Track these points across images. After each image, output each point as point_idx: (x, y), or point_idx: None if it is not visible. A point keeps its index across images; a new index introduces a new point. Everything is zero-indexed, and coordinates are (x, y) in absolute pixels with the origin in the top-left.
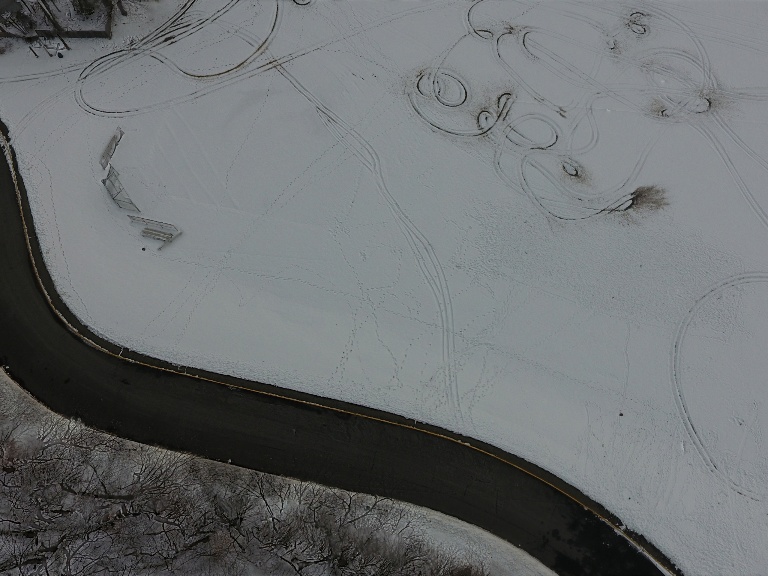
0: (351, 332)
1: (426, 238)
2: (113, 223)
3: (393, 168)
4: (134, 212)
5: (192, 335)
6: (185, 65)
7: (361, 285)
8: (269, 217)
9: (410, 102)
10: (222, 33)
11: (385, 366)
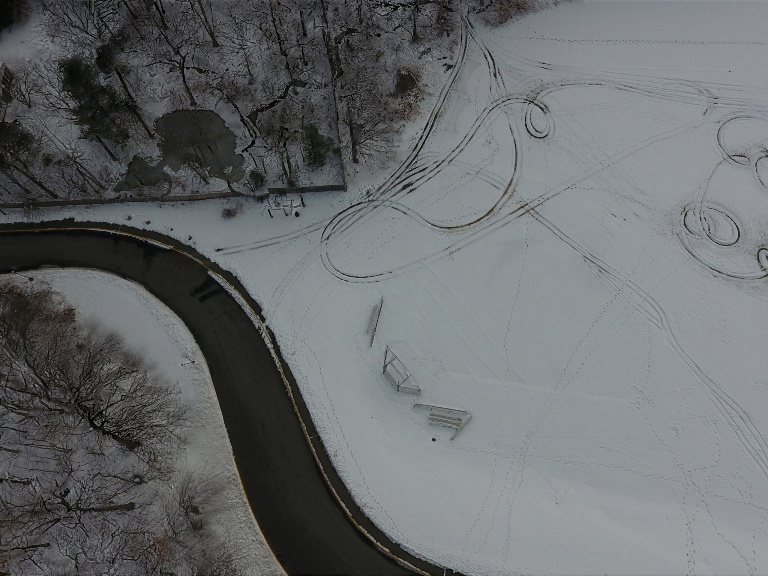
0: (686, 527)
1: (738, 404)
2: (394, 410)
3: (682, 323)
4: (414, 395)
5: (519, 547)
6: (431, 216)
7: (681, 467)
8: (562, 391)
9: (681, 243)
10: (462, 176)
11: (737, 568)
